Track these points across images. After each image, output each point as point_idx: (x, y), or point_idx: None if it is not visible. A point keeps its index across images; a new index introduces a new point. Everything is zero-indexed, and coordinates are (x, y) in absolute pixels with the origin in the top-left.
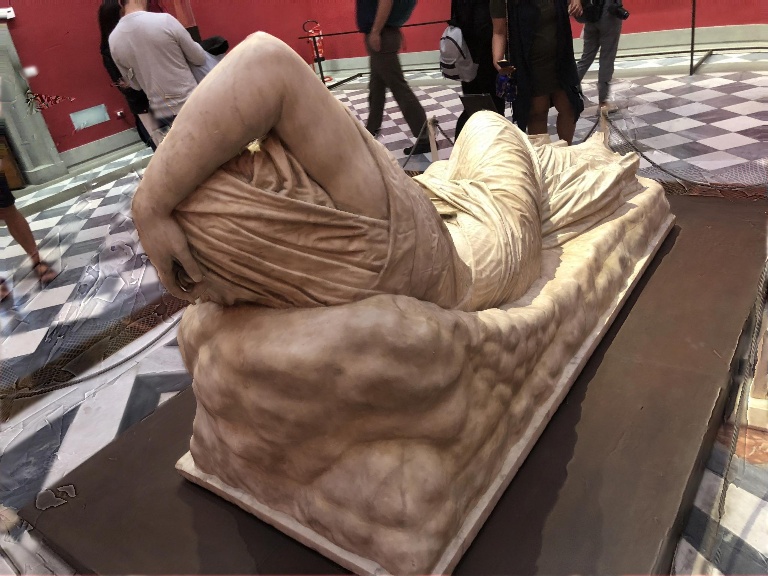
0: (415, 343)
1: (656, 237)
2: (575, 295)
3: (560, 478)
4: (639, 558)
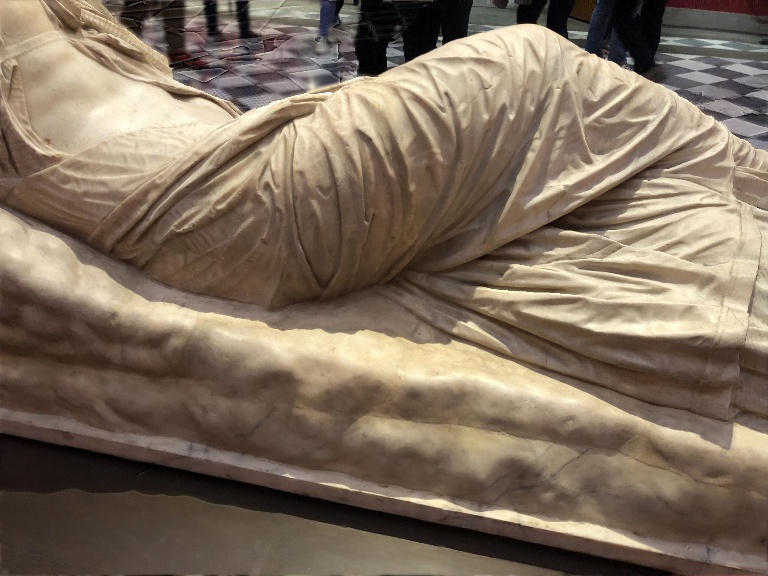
0: None
1: (764, 562)
2: (254, 373)
3: None
4: None
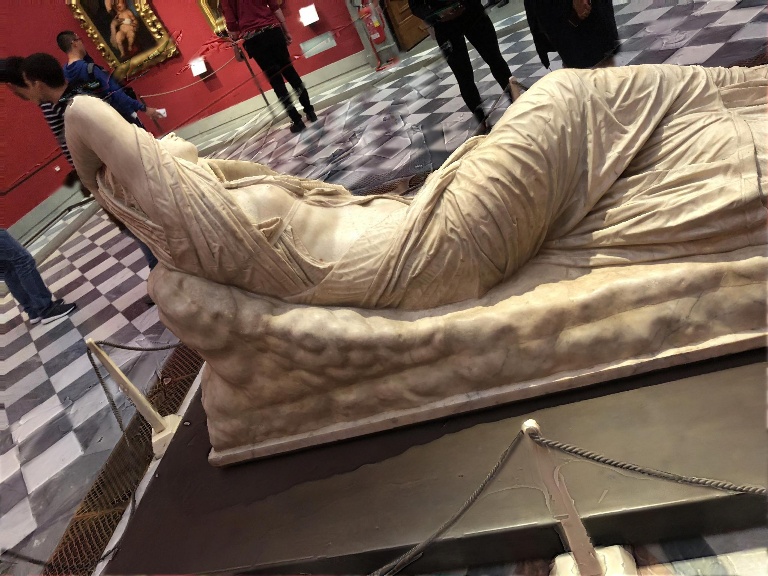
0: (171, 314)
1: None
2: (490, 334)
3: (349, 468)
4: (288, 549)
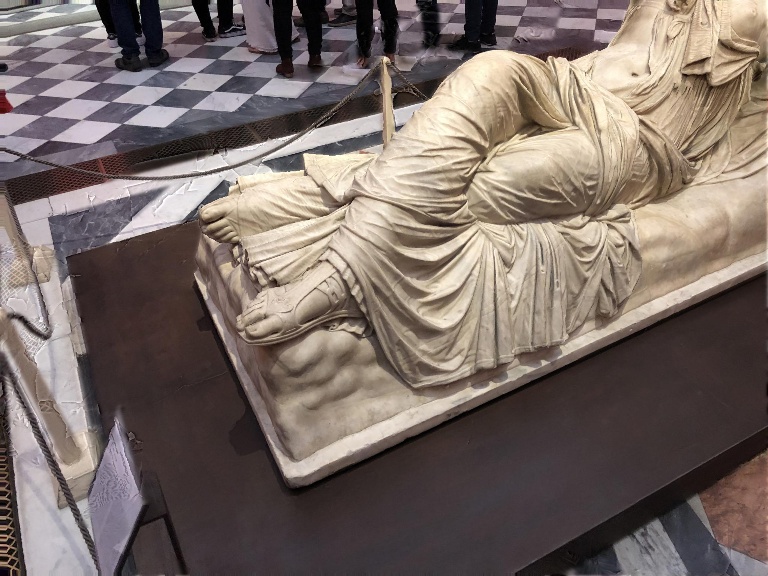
0: None
1: None
2: None
3: None
4: None
